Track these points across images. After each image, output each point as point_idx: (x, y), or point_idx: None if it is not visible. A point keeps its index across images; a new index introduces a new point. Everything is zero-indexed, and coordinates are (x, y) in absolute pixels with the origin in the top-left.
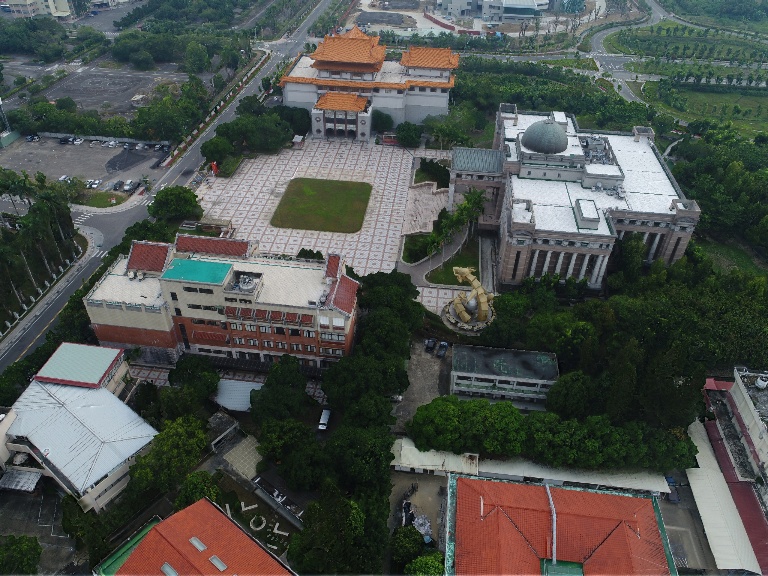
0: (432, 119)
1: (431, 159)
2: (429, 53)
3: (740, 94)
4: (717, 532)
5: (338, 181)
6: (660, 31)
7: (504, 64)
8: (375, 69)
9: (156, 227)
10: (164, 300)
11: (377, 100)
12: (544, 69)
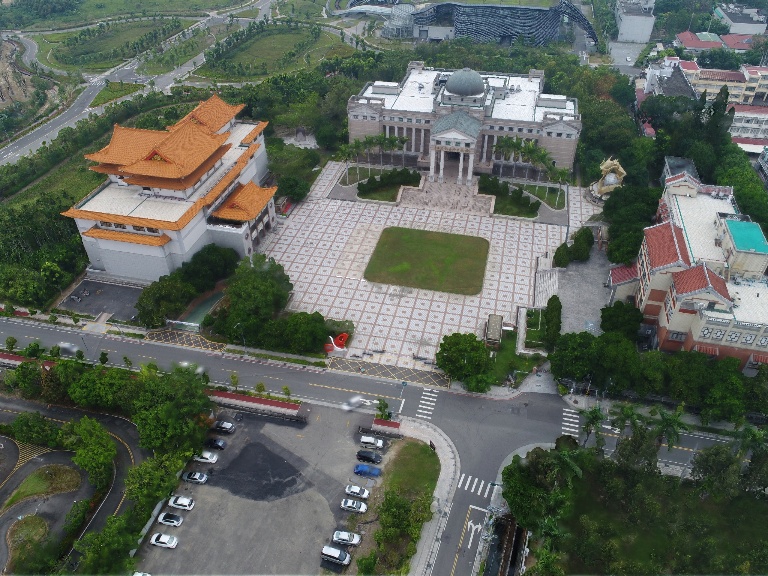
0: (275, 165)
1: (372, 176)
2: (209, 109)
3: (241, 52)
4: (755, 149)
5: (378, 247)
6: (74, 42)
7: (105, 119)
8: (225, 147)
9: (586, 332)
10: (762, 277)
11: (241, 180)
12: (133, 104)
